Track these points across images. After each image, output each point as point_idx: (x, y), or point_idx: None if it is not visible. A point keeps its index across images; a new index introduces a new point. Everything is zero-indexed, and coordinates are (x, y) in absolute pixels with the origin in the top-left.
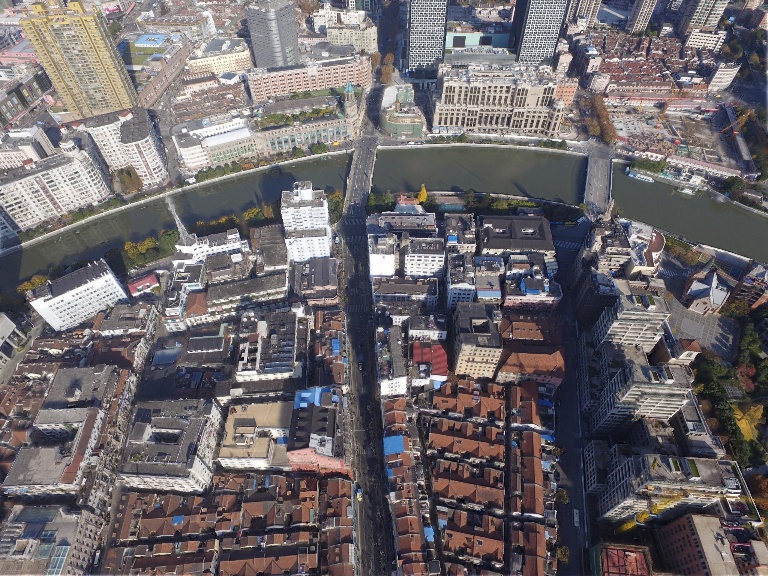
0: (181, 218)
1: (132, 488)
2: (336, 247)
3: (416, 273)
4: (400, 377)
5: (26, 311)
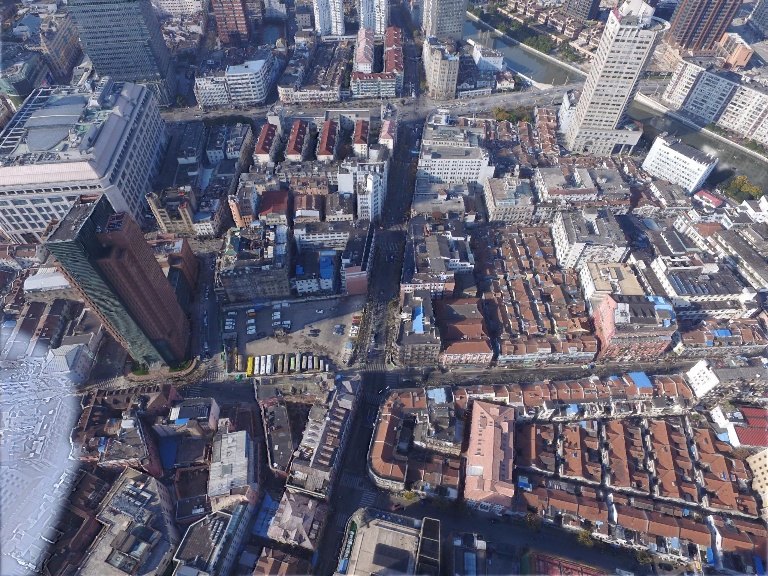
0: None
1: (551, 229)
2: None
3: None
4: (715, 375)
5: (649, 149)
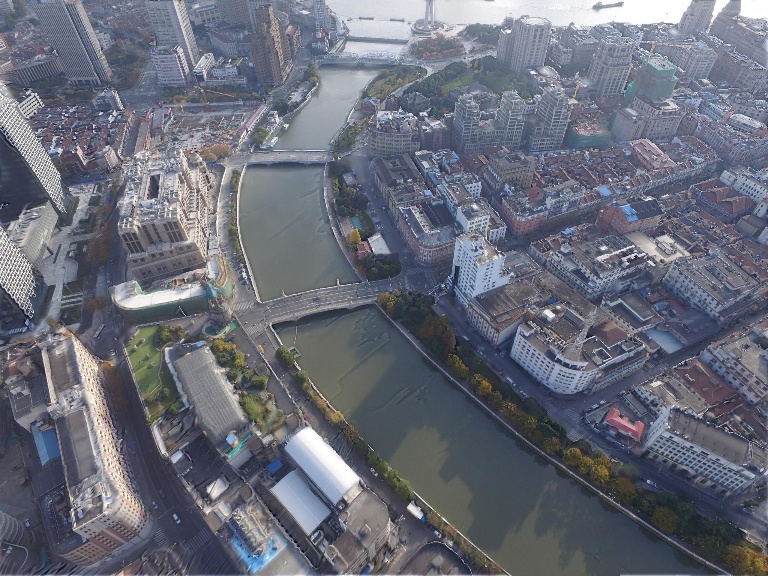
0: (495, 472)
1: None
2: None
3: None
4: None
5: None
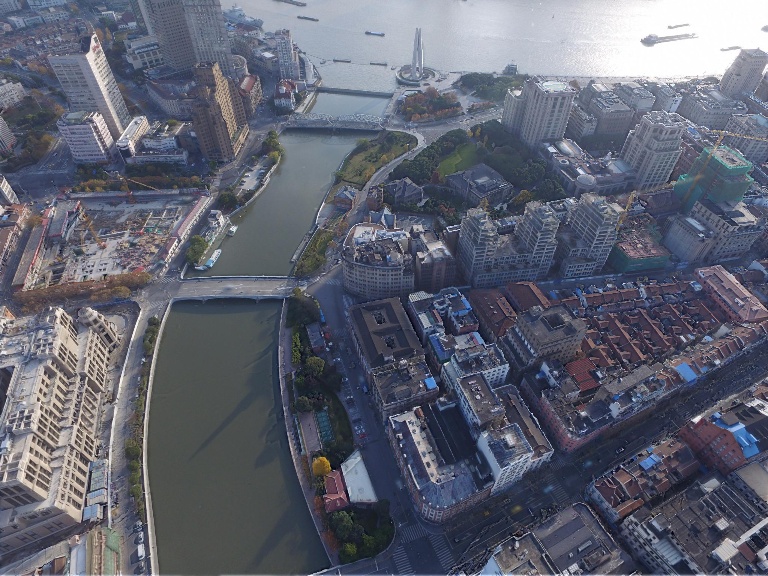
0: None
1: None
2: (474, 572)
3: None
4: (652, 369)
5: None
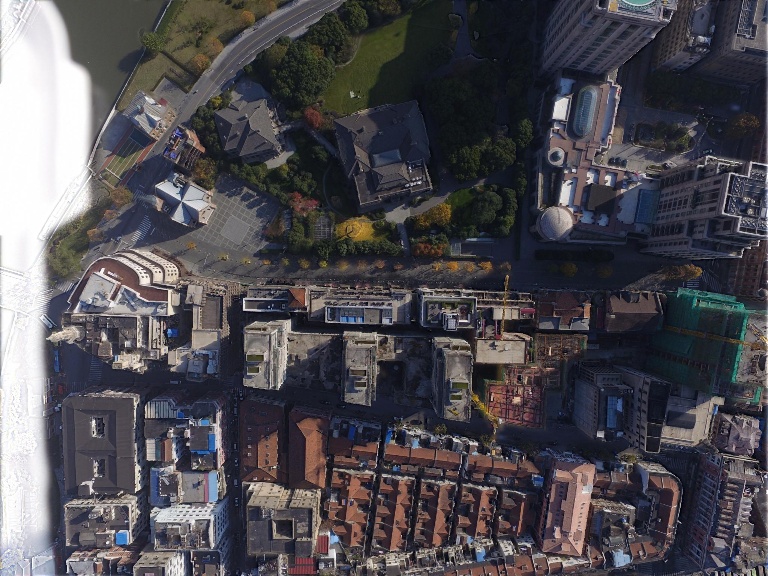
0: None
1: None
2: None
3: (182, 575)
4: None
5: None
